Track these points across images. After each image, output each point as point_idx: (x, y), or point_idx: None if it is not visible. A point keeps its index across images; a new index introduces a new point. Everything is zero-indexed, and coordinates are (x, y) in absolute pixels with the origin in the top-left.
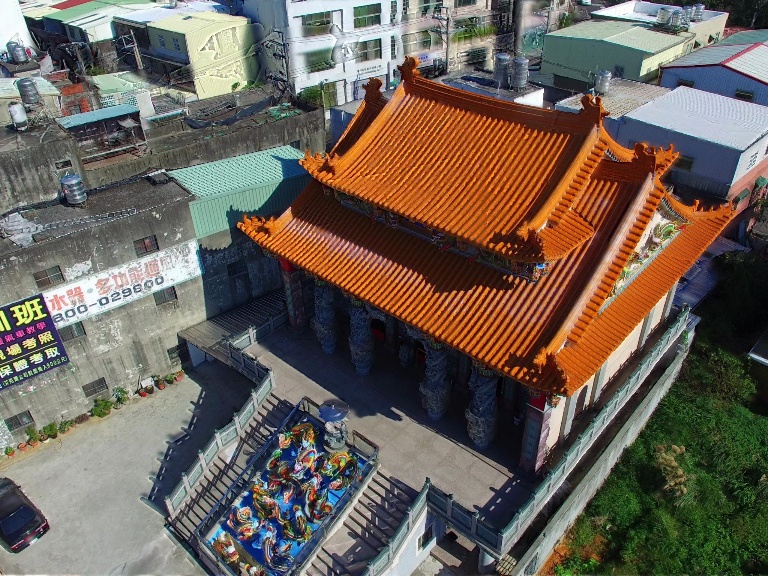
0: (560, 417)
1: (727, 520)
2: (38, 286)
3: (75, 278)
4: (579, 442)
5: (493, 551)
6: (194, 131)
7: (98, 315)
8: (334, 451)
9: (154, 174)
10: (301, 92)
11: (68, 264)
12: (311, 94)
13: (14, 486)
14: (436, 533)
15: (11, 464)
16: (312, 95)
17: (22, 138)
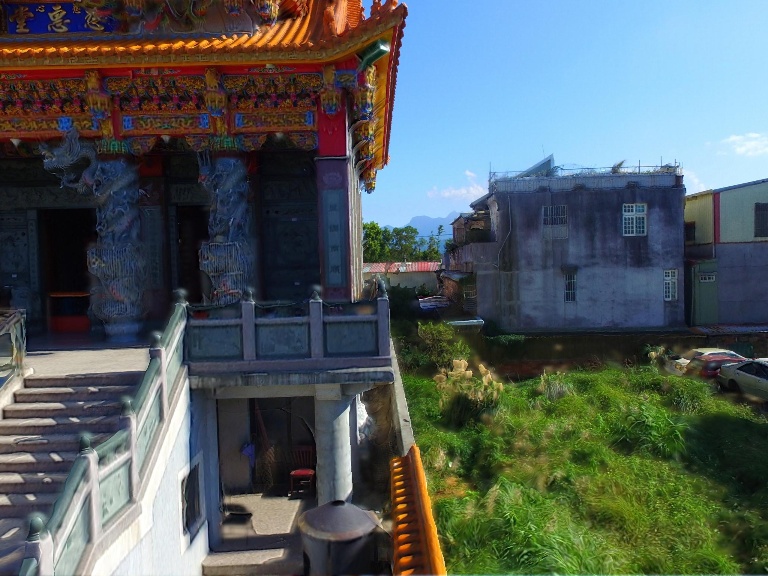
0: None
1: (551, 414)
2: None
3: None
4: None
5: (373, 367)
6: None
7: None
8: None
9: None
10: None
11: None
12: None
13: None
14: (205, 508)
15: None
16: None
17: None
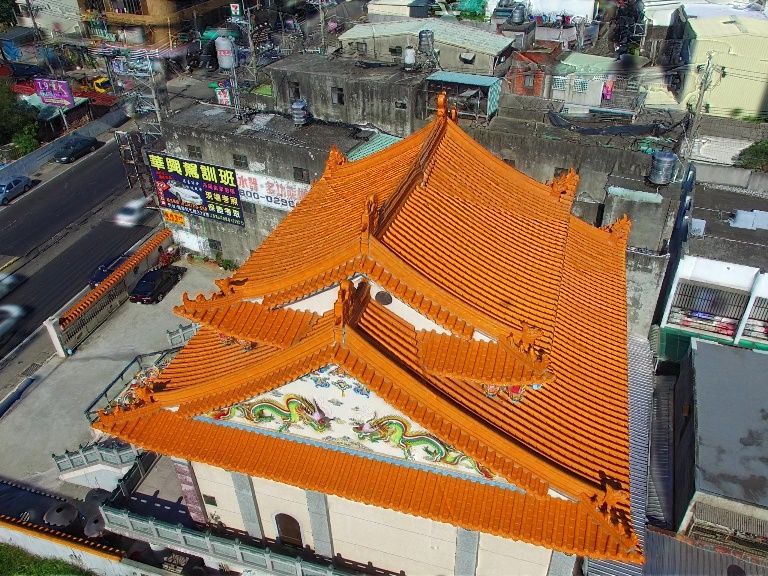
0: (237, 505)
1: None
2: (236, 164)
3: (255, 171)
4: (233, 544)
5: None
6: (549, 126)
7: (265, 206)
8: None
9: (367, 130)
10: (760, 142)
11: (252, 159)
12: (766, 148)
13: (172, 273)
14: None
15: (199, 266)
16: (766, 150)
17: (396, 75)
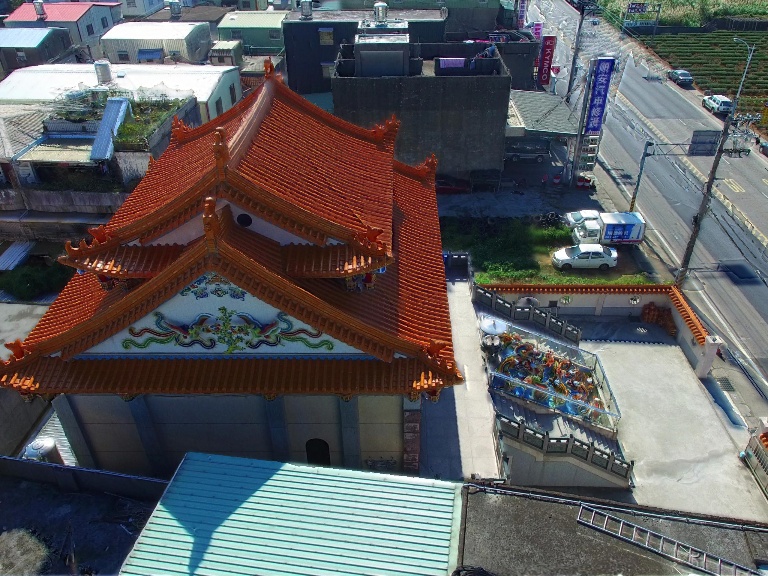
0: None
1: None
2: None
3: None
4: None
5: None
6: None
7: None
8: (498, 354)
9: None
10: None
11: None
12: None
13: None
14: None
15: None
16: None
17: None
